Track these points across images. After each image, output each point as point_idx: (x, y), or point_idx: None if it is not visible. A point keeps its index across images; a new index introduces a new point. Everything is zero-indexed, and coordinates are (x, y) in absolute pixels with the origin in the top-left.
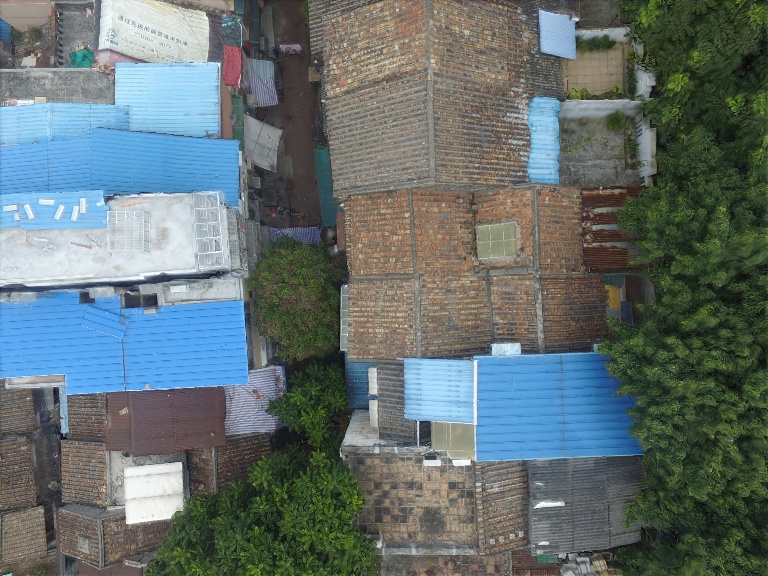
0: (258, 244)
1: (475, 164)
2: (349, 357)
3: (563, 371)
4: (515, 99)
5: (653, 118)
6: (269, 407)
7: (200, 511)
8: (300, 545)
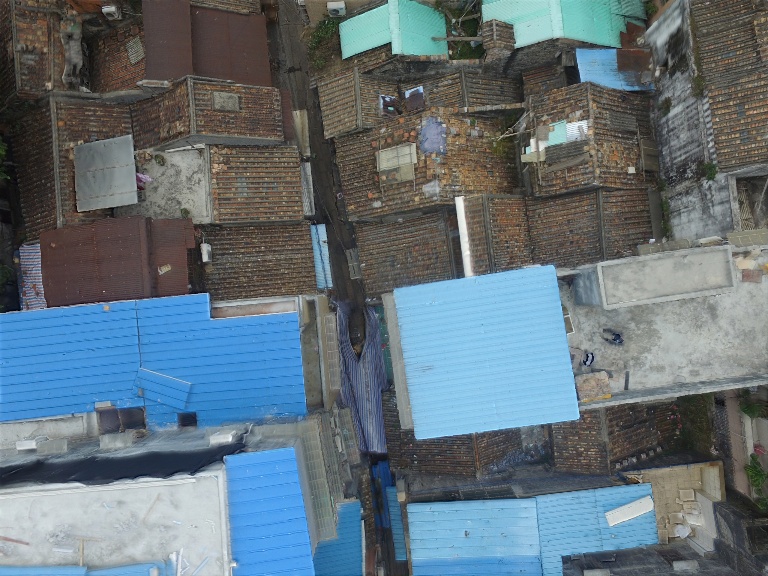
0: None
1: None
2: None
3: None
4: None
5: None
6: None
7: None
8: None
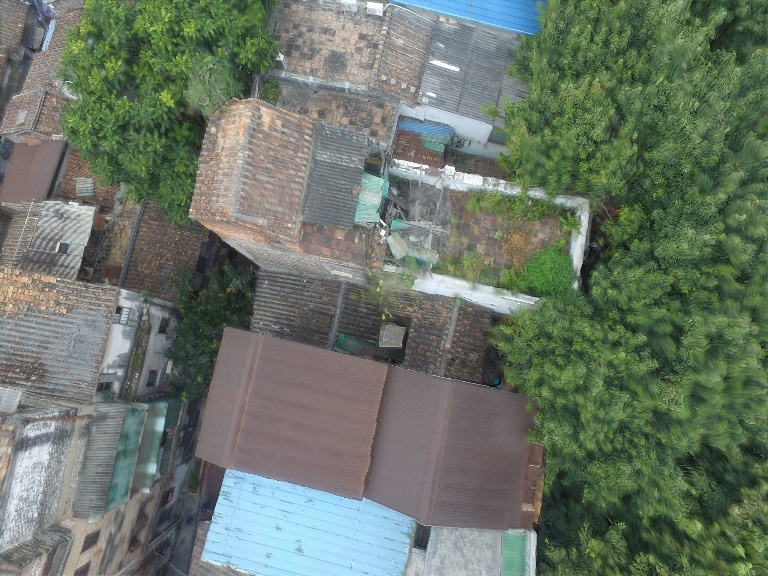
0: None
1: None
2: None
3: None
4: None
5: None
6: None
7: None
8: None
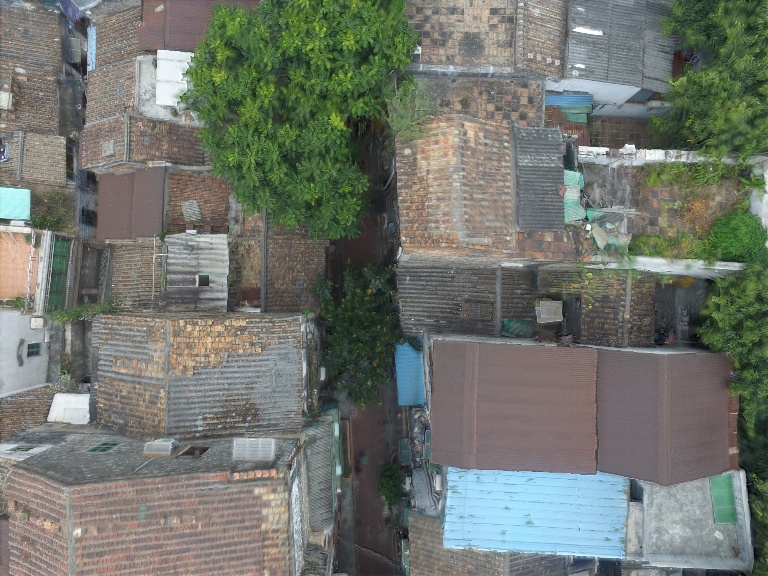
0: None
1: None
2: None
3: None
4: None
5: None
6: None
7: None
8: None
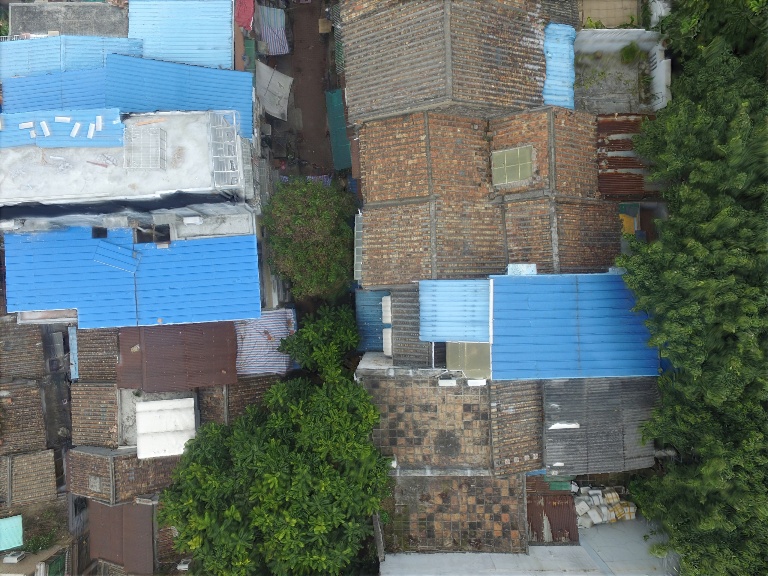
0: (270, 184)
1: (491, 85)
2: (363, 285)
3: (579, 291)
4: (531, 24)
5: (671, 32)
6: (281, 345)
7: (214, 433)
8: (317, 455)
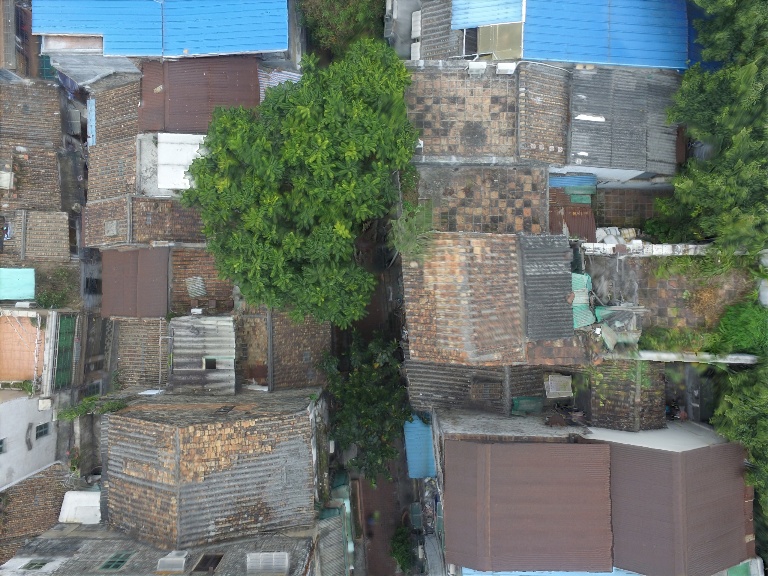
0: None
1: None
2: None
3: None
4: None
5: None
6: None
7: (242, 113)
8: (349, 94)
